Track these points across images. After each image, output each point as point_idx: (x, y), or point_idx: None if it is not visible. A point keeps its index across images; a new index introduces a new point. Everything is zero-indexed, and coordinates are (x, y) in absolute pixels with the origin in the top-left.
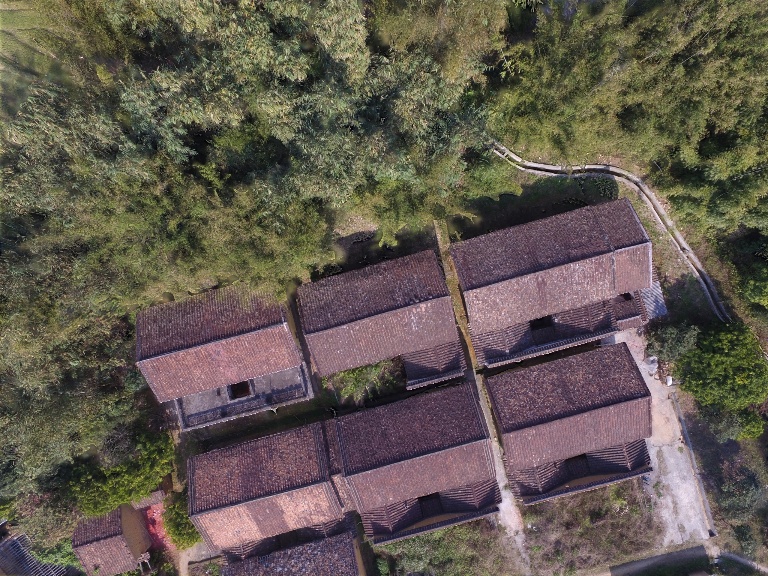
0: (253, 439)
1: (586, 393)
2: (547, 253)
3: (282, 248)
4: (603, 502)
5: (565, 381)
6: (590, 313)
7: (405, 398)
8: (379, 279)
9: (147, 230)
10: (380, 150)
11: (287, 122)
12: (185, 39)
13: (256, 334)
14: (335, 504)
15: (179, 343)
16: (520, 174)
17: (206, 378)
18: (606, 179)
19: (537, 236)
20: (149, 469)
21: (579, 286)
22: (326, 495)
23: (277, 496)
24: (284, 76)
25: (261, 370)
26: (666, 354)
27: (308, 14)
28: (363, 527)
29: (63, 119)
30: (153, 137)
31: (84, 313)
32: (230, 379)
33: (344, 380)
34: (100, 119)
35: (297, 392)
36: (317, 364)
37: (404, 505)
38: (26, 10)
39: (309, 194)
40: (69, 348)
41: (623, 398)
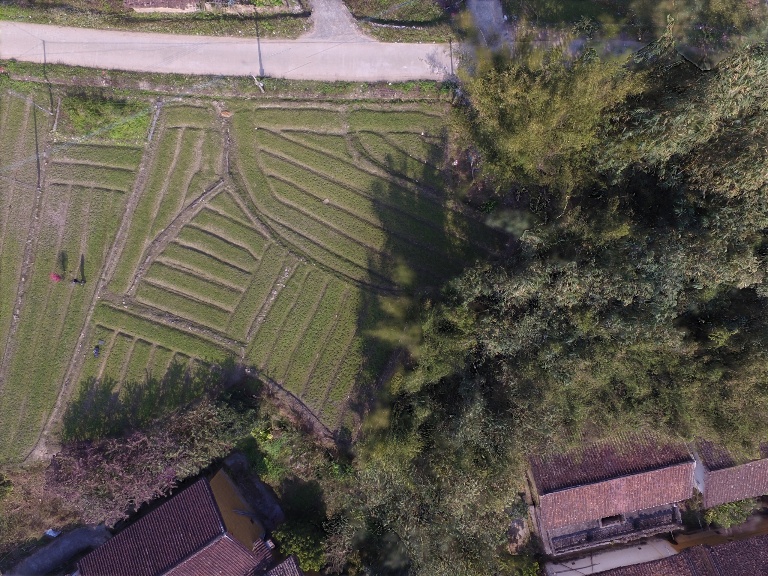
0: (592, 555)
1: None
2: None
3: None
4: None
5: None
6: None
7: None
8: None
9: None
10: None
11: None
12: (670, 186)
13: (663, 470)
14: None
15: (582, 476)
16: None
17: (598, 509)
18: None
19: None
20: None
21: None
22: None
23: None
24: None
25: (652, 502)
26: None
27: None
28: None
29: None
30: None
31: None
32: (619, 510)
33: None
34: (642, 287)
35: (665, 518)
36: (707, 497)
37: None
38: (399, 112)
39: None
40: None
41: None
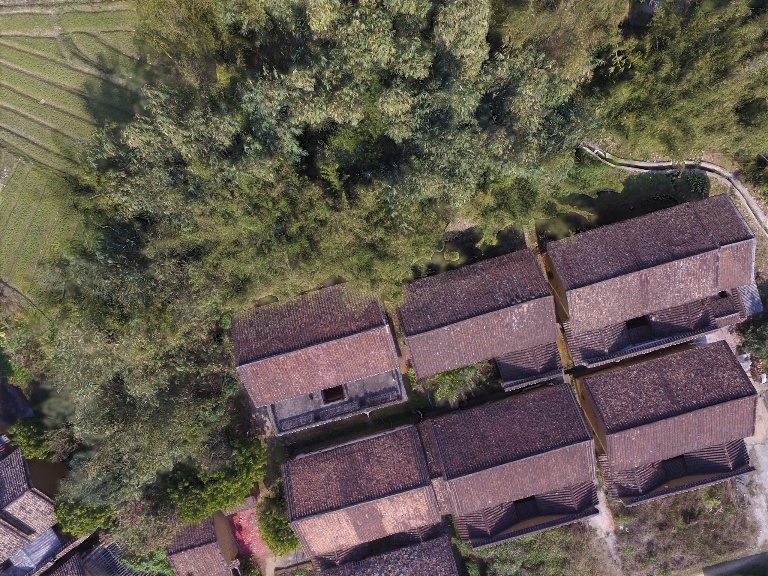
0: (340, 443)
1: (690, 392)
2: (650, 251)
3: (407, 249)
4: (696, 502)
5: (666, 380)
6: (690, 311)
7: (493, 399)
8: (477, 279)
9: (262, 233)
10: (505, 148)
11: (404, 121)
12: (296, 38)
13: (357, 337)
14: (435, 508)
15: (279, 347)
16: (611, 171)
17: (304, 382)
18: (698, 175)
19: (637, 233)
20: (246, 475)
21: (682, 284)
22: (426, 499)
23: (378, 501)
24: (407, 74)
25: (359, 373)
26: (765, 351)
27: (429, 10)
28: (451, 530)
29: (183, 121)
30: (269, 138)
31: (189, 318)
32: (328, 383)
33: (436, 382)
34: (226, 120)
35: (391, 395)
36: (415, 366)
37: (500, 508)
38: (110, 12)
39: (428, 194)
40: (172, 354)
41: (729, 397)
